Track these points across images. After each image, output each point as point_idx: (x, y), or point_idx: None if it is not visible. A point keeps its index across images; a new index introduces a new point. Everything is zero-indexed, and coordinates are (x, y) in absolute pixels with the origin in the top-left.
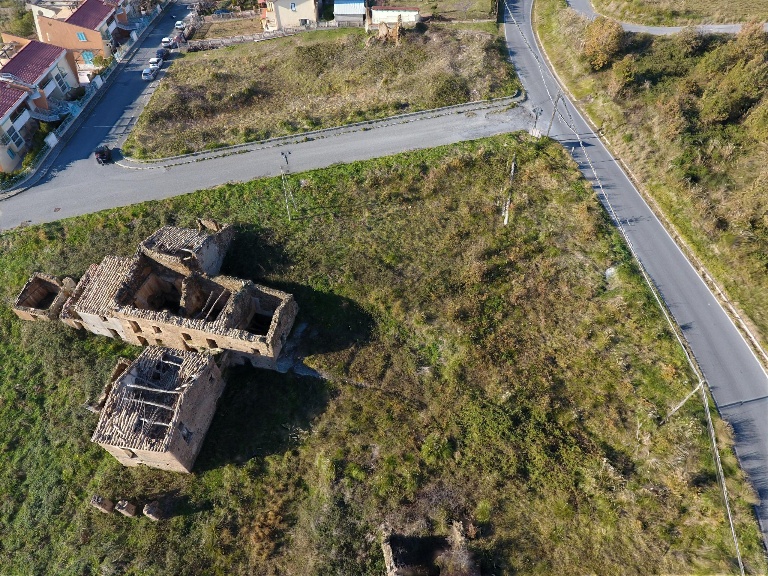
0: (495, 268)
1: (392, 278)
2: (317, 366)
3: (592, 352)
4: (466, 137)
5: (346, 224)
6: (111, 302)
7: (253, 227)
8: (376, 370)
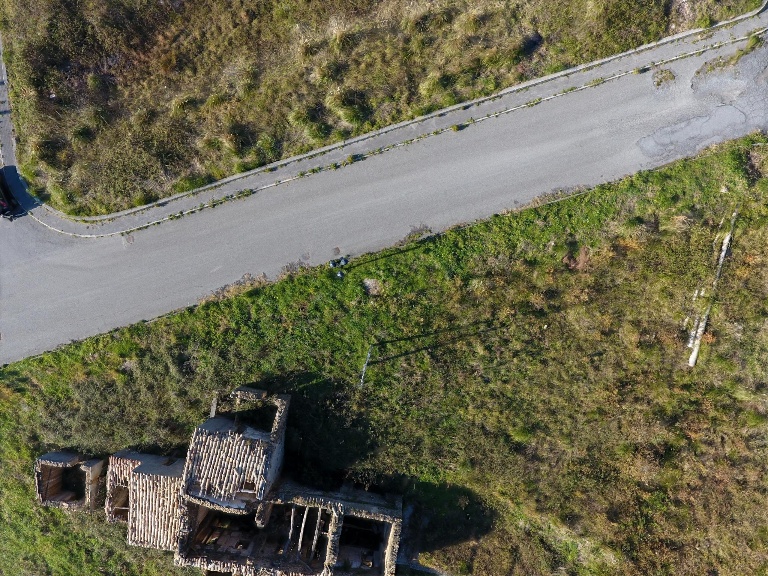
0: (665, 447)
1: (524, 467)
2: (437, 568)
3: (767, 574)
4: (650, 156)
5: (450, 370)
6: (176, 553)
7: (312, 379)
8: (504, 567)
